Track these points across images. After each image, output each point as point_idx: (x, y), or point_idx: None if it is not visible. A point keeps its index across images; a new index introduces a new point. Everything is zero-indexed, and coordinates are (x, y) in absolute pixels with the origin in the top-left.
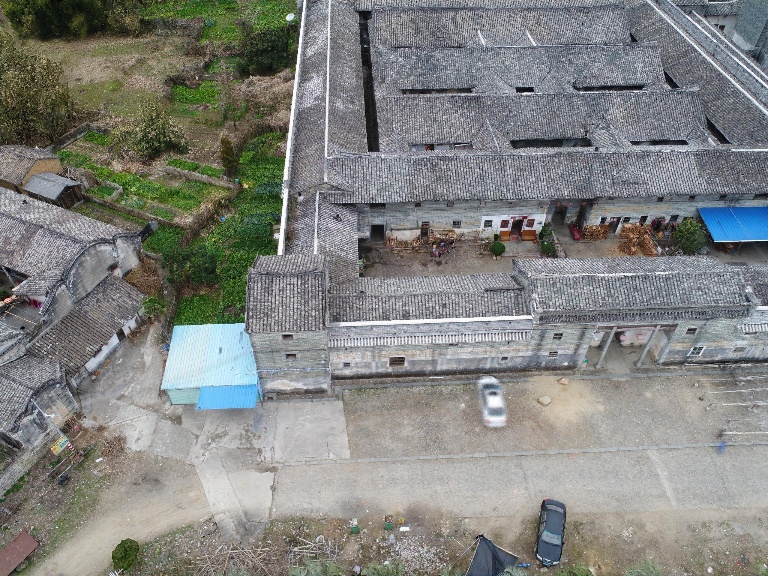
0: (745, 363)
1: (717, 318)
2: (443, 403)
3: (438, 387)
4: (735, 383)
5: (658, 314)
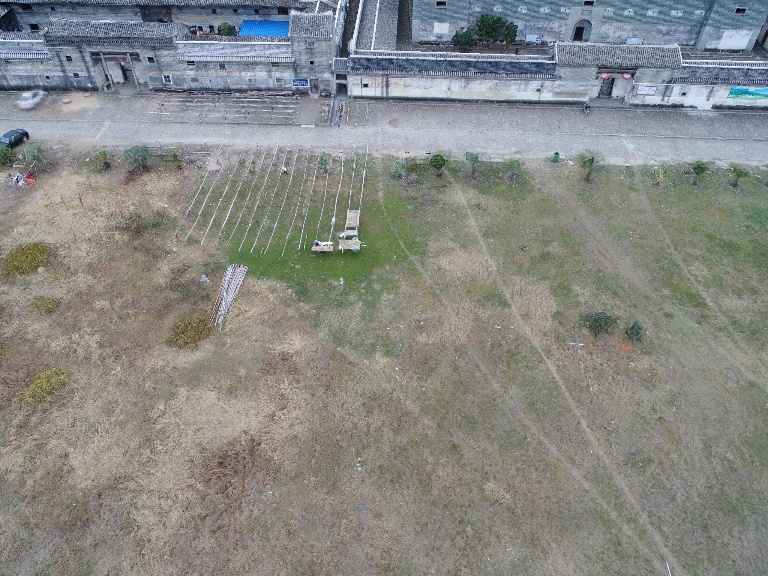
0: (203, 90)
1: (159, 48)
2: (7, 101)
3: (11, 95)
4: (192, 101)
5: (119, 42)
